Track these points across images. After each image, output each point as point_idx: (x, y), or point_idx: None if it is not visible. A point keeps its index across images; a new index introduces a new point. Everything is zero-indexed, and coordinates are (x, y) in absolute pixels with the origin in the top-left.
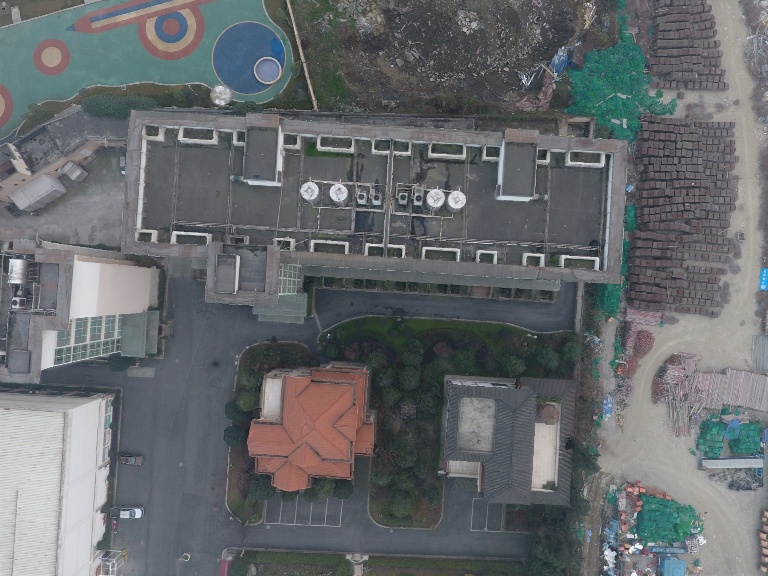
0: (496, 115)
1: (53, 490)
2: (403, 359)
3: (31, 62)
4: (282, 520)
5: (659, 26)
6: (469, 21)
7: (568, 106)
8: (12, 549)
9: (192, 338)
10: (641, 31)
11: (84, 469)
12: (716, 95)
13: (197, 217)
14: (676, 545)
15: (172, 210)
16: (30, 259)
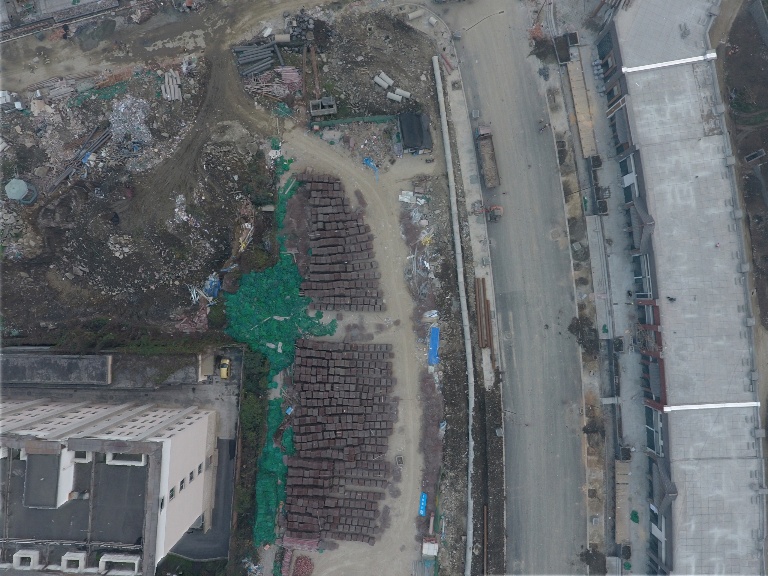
0: (134, 350)
1: None
2: None
3: None
4: None
5: (312, 250)
6: (120, 247)
7: (226, 328)
8: None
9: None
10: (299, 252)
11: None
12: (376, 315)
13: None
14: None
15: None
16: None
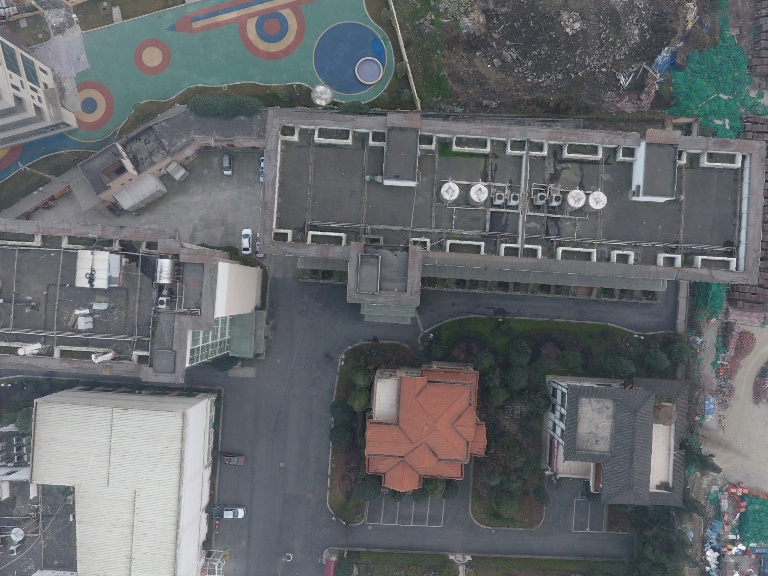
0: (603, 116)
1: (172, 490)
2: (511, 359)
3: (132, 62)
4: (384, 520)
5: (762, 27)
6: (572, 22)
7: (669, 107)
8: (130, 549)
9: (293, 338)
10: (743, 32)
11: (195, 469)
12: None
13: (331, 217)
14: None
15: (307, 210)
16: (174, 259)
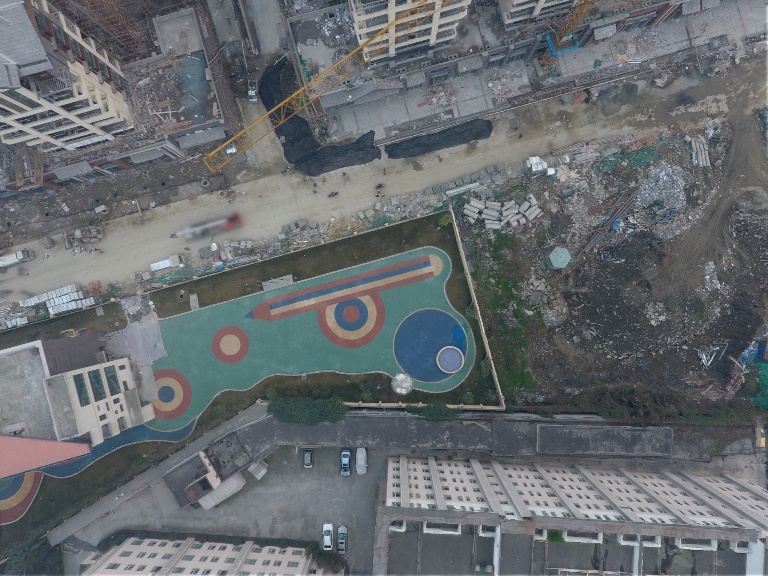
0: (693, 421)
1: None
2: None
3: (210, 350)
4: None
5: None
6: (658, 315)
7: (755, 396)
8: None
9: None
10: None
11: None
12: None
13: None
14: None
15: None
16: None
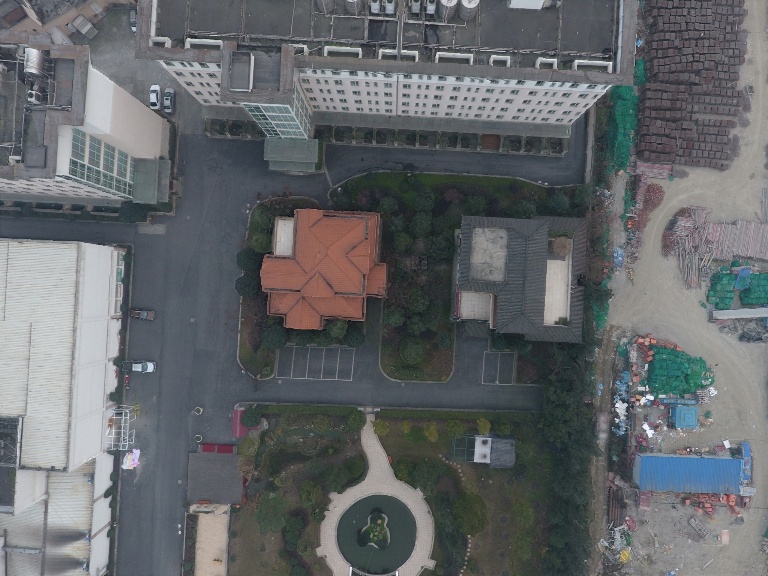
0: None
1: (67, 322)
2: (414, 205)
3: None
4: (294, 374)
5: None
6: None
7: None
8: (26, 381)
9: (203, 195)
10: None
11: (97, 311)
12: None
13: (210, 28)
14: (687, 397)
15: (186, 19)
16: None
